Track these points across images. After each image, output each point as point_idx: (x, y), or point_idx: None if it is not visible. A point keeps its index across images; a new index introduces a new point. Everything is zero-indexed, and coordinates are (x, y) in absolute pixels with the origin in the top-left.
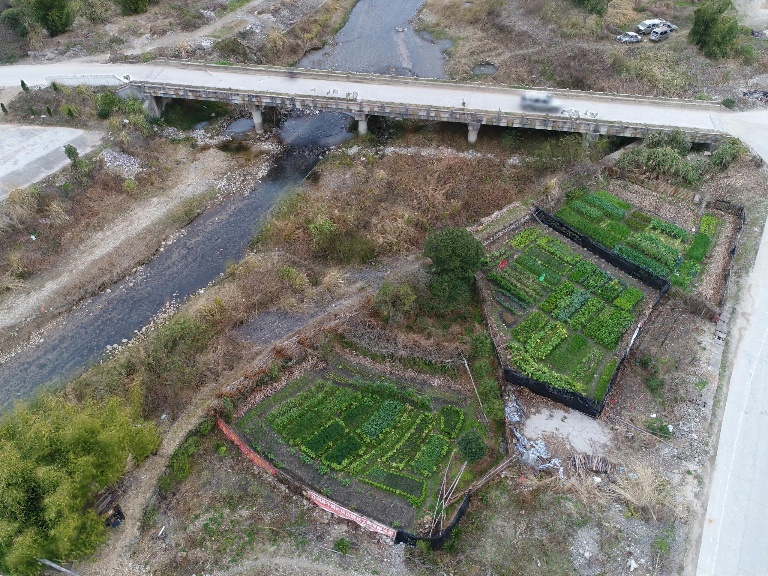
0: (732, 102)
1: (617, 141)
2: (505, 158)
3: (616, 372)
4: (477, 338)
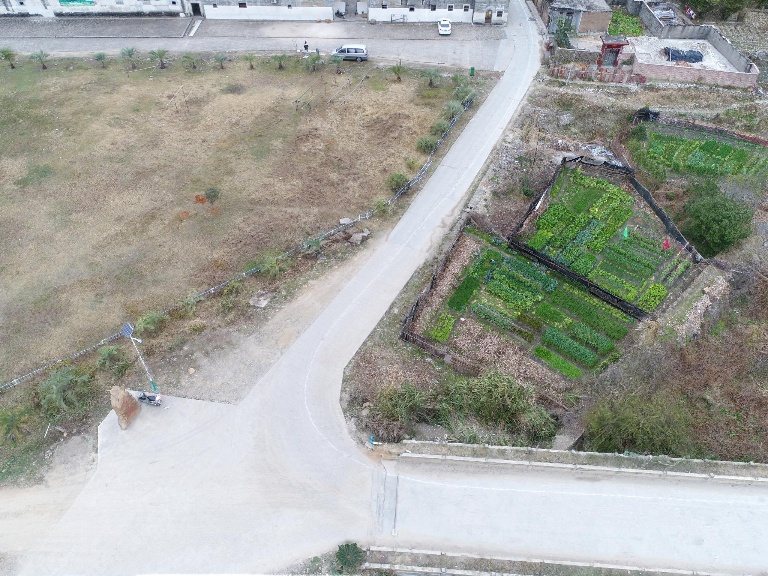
0: (344, 555)
1: None
2: None
3: None
4: None
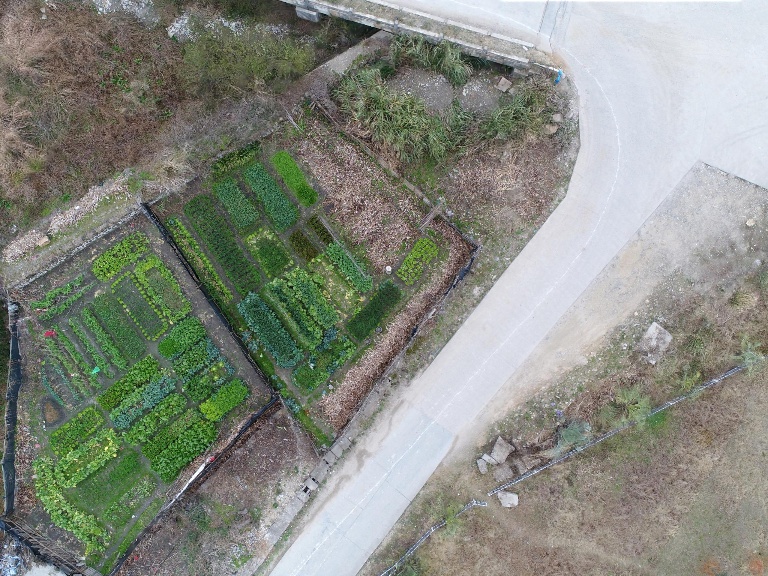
0: None
1: (354, 27)
2: (168, 17)
3: (136, 541)
4: None
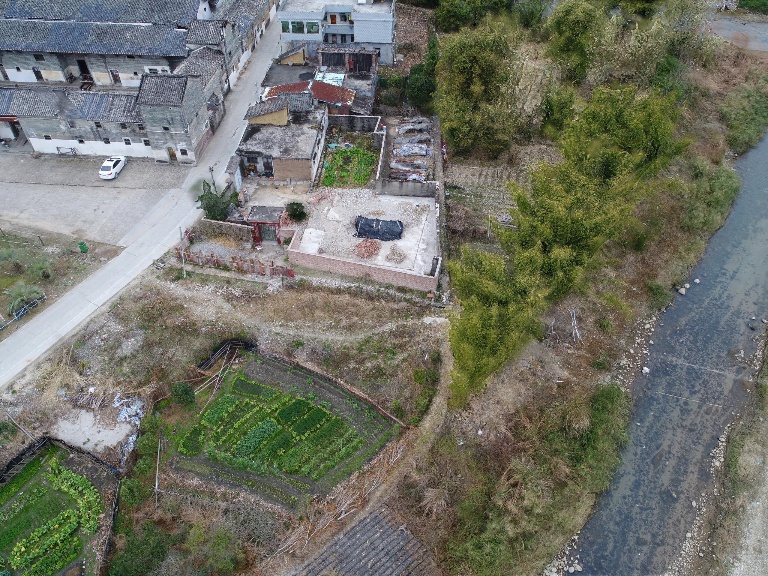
0: None
1: None
2: None
3: (4, 473)
4: (135, 484)
